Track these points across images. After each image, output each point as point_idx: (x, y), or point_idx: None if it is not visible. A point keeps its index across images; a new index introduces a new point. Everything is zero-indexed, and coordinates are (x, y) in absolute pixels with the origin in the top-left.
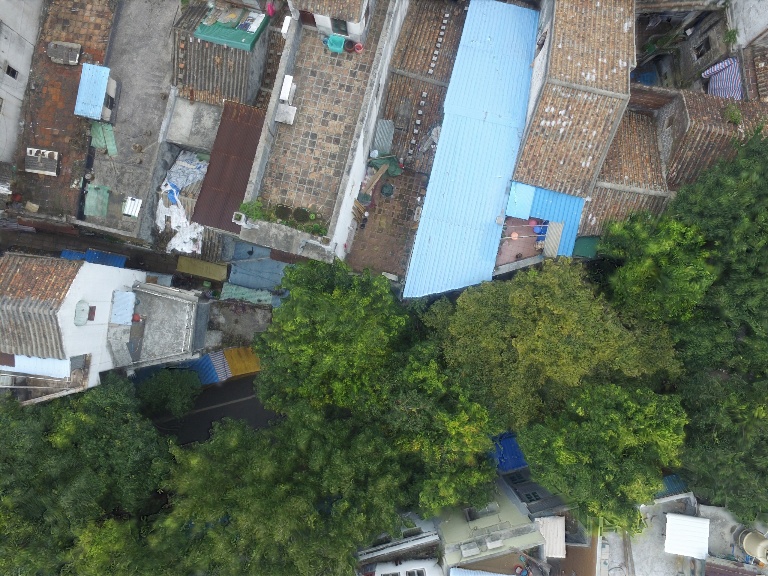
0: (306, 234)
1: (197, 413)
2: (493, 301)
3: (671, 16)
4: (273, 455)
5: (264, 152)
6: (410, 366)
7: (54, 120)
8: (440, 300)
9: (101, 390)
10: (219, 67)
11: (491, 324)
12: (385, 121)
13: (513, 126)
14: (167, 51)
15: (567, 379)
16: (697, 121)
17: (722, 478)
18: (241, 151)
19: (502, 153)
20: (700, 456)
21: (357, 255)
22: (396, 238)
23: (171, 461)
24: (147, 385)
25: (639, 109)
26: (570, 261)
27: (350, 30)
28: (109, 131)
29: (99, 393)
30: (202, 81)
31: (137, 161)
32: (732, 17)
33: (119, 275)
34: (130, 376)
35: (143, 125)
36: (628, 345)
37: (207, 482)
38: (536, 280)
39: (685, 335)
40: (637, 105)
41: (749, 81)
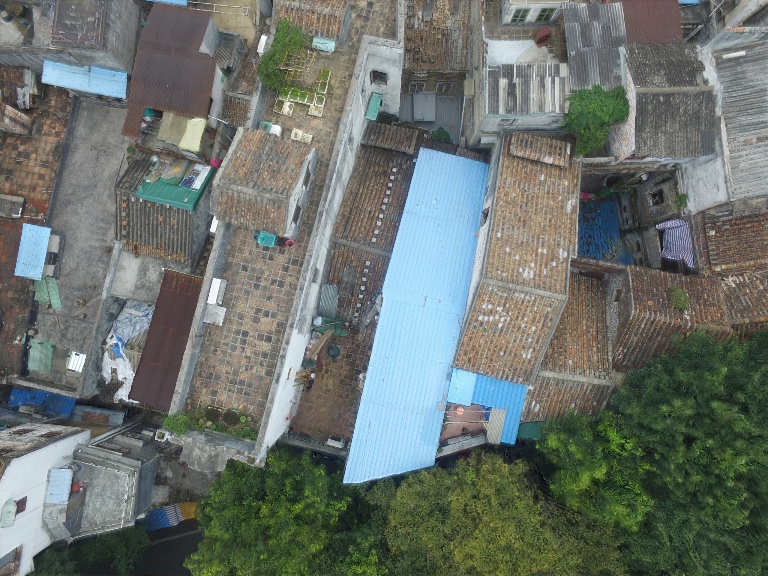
0: (232, 450)
1: (152, 547)
2: (434, 492)
3: None
4: None
5: (191, 358)
6: (349, 558)
7: None
8: (383, 481)
9: None
10: (162, 224)
11: (431, 519)
12: (329, 285)
13: (453, 312)
14: (112, 201)
15: None
16: (642, 308)
17: None
18: (180, 323)
19: (442, 339)
20: None
21: (304, 417)
22: (343, 399)
23: None
24: (91, 546)
25: (590, 270)
26: (507, 470)
27: None
28: (53, 284)
29: None
30: (146, 237)
31: (81, 317)
32: (683, 180)
33: (56, 450)
34: (72, 542)
35: (87, 278)
36: (570, 550)
37: None
38: (475, 480)
39: (629, 539)
40: (587, 268)
41: (700, 248)
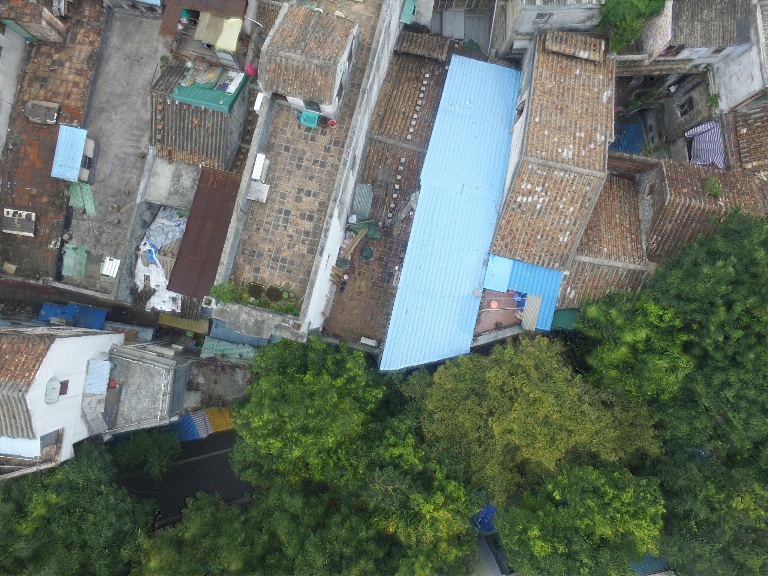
0: (277, 318)
1: (179, 465)
2: (470, 376)
3: (654, 75)
4: (246, 536)
5: (236, 232)
6: (386, 441)
7: (32, 180)
8: (418, 371)
9: (74, 465)
10: (197, 128)
11: (468, 400)
12: (364, 185)
13: (490, 199)
14: (146, 109)
15: (543, 462)
16: (677, 194)
17: (700, 569)
18: (217, 218)
19: (479, 225)
20: (677, 546)
21: (336, 318)
22: (376, 301)
23: (141, 547)
24: (125, 447)
25: (621, 172)
26: (546, 342)
27: (323, 109)
28: (87, 190)
29: (72, 468)
30: (180, 141)
31: (115, 221)
32: (714, 81)
33: (94, 343)
34: (107, 441)
35: (121, 184)
36: (606, 425)
37: (175, 574)
38: (513, 358)
39: (664, 415)
40: (618, 169)
41: (731, 146)
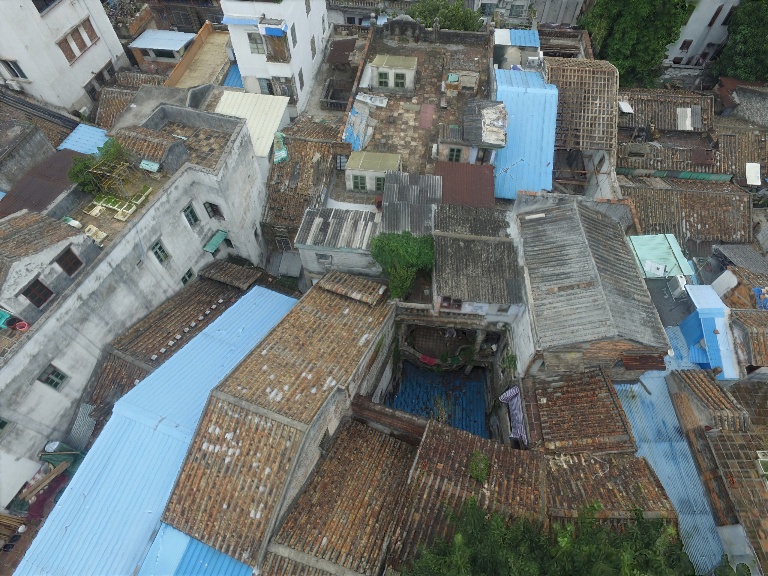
0: None
1: None
2: None
3: (465, 330)
4: None
5: None
6: None
7: None
8: None
9: None
10: None
11: None
12: (90, 406)
13: (187, 441)
14: None
15: None
16: (425, 470)
17: None
18: None
19: (163, 477)
20: None
21: None
22: None
23: None
24: None
25: (403, 433)
26: None
27: None
28: None
29: None
30: None
31: None
32: (513, 341)
33: None
34: None
35: None
36: None
37: None
38: None
39: None
40: (398, 428)
41: (531, 418)
